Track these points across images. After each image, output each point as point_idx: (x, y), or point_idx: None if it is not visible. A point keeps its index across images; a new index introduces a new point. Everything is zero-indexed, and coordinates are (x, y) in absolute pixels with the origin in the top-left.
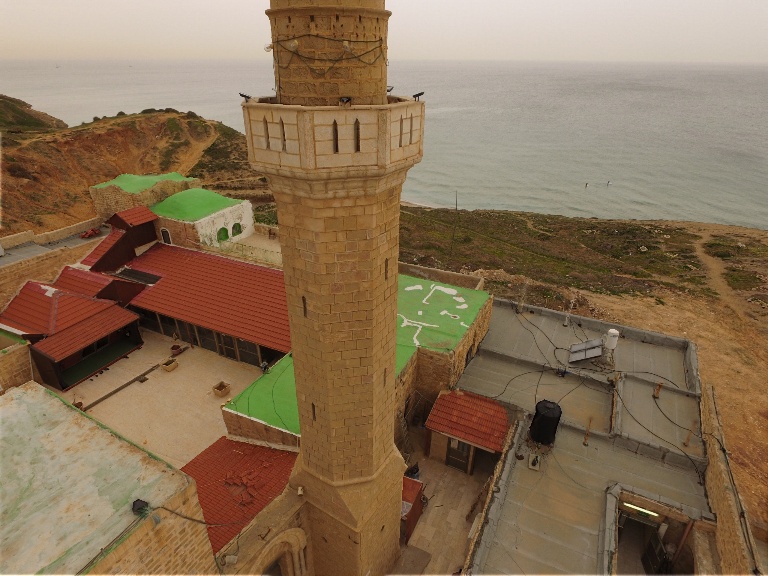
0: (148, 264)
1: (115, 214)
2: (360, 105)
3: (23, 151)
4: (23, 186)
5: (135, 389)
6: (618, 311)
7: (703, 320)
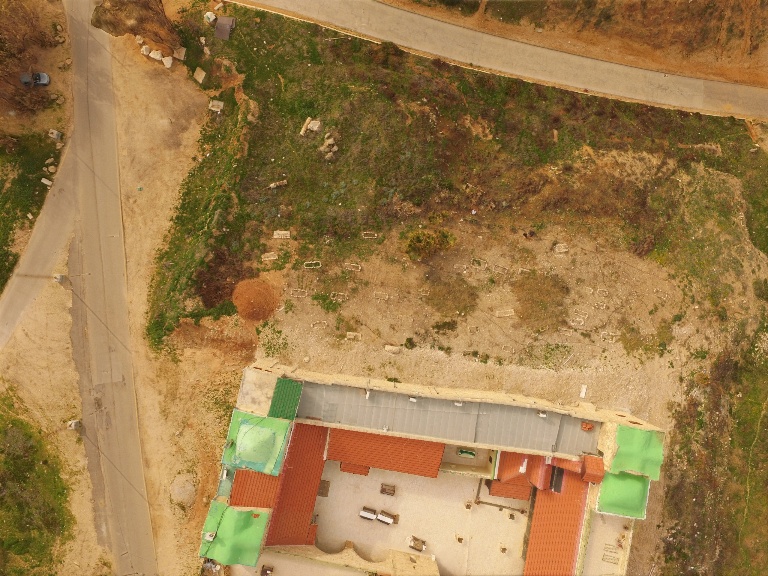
0: (570, 477)
1: (586, 471)
2: None
3: None
4: None
5: (495, 511)
6: None
7: None
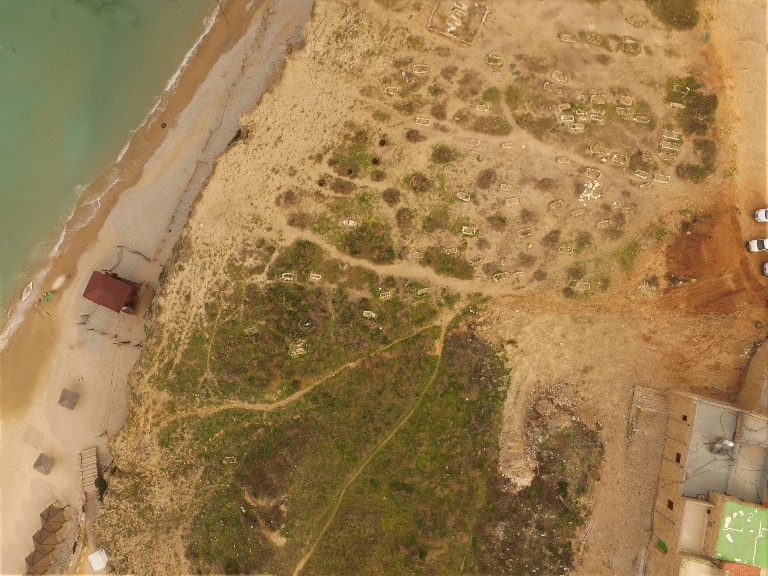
0: None
1: None
2: None
3: None
4: None
5: None
6: (541, 379)
7: (535, 324)
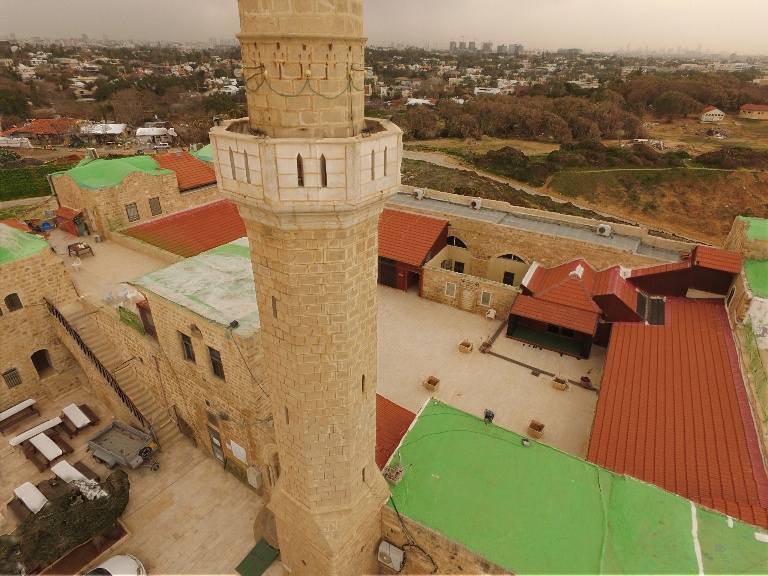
0: (680, 308)
1: (697, 246)
2: (222, 127)
3: None
4: None
5: (521, 372)
6: None
7: None
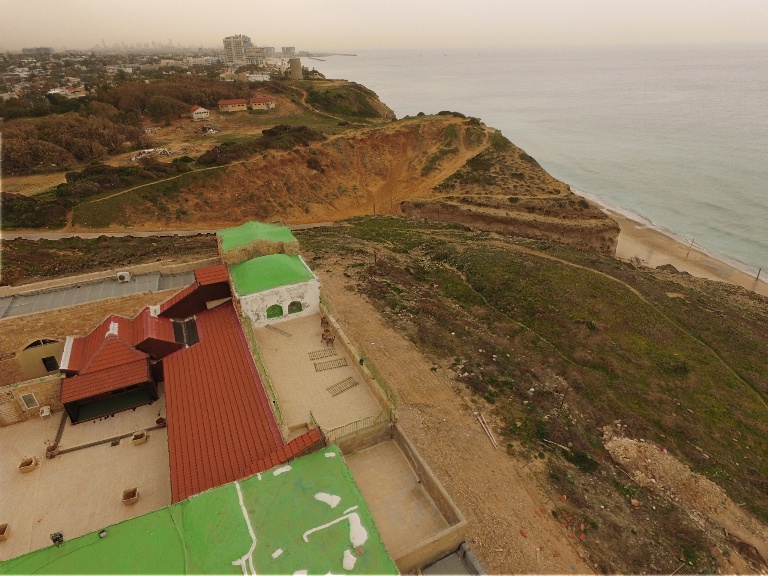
0: (206, 321)
1: (194, 270)
2: None
3: (324, 146)
4: (310, 177)
5: (101, 451)
6: None
7: None
